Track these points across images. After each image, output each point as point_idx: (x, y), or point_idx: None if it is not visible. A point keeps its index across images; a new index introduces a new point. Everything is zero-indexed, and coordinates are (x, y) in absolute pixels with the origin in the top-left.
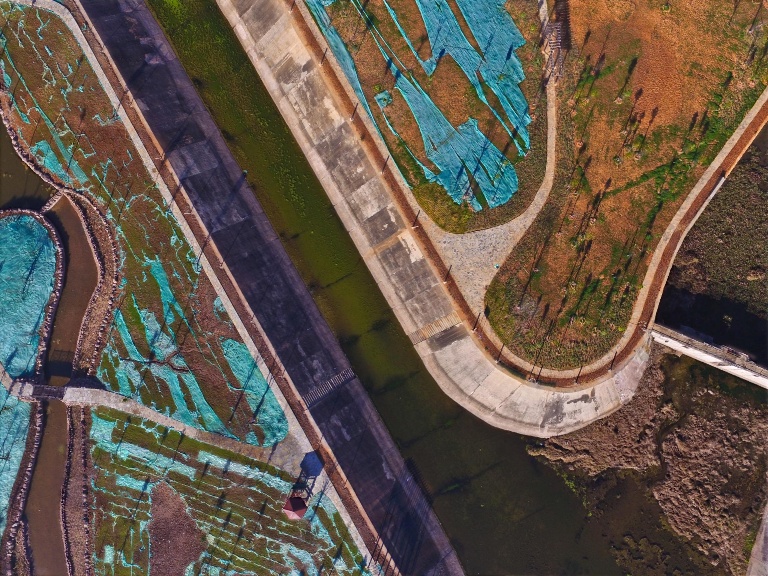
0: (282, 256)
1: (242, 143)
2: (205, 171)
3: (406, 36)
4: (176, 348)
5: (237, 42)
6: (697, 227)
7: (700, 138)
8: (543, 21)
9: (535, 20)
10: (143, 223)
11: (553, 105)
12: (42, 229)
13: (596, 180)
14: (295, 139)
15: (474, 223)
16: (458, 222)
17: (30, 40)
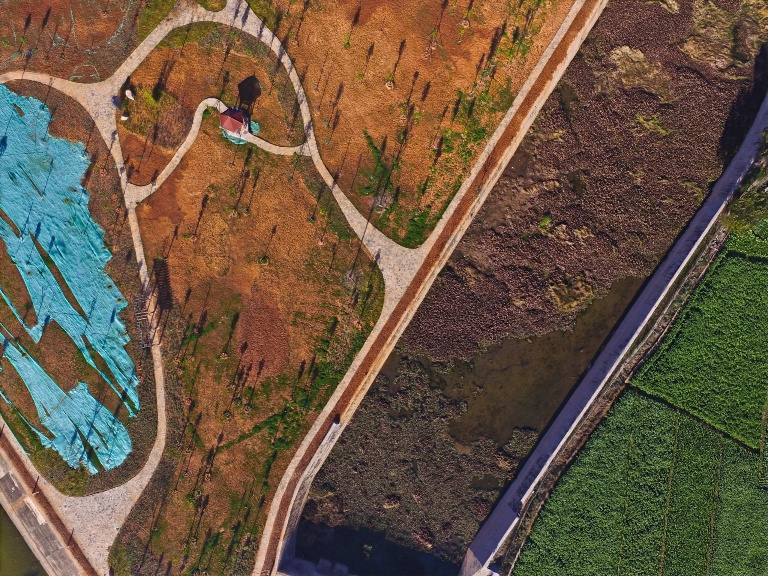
0: None
1: None
2: None
3: (11, 304)
4: None
5: None
6: (331, 460)
7: (310, 384)
8: (143, 282)
9: (136, 282)
10: None
11: (159, 365)
12: None
13: (208, 436)
14: None
15: (91, 486)
16: (76, 486)
17: None
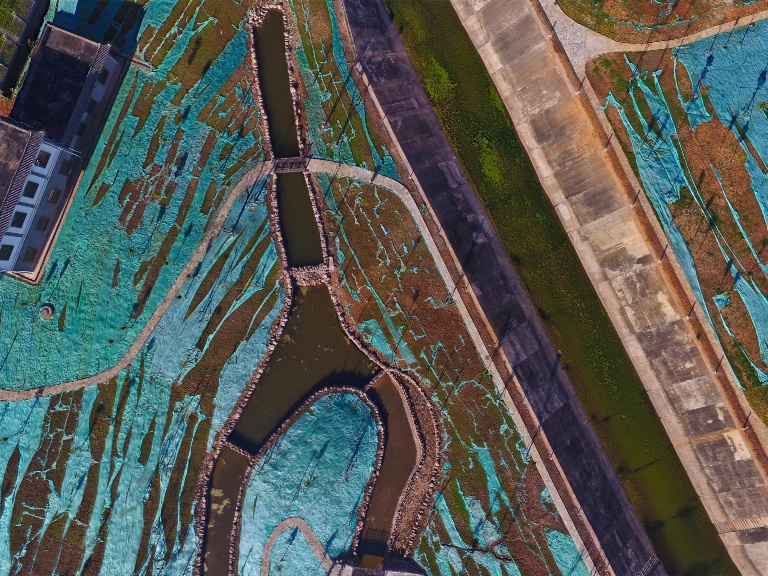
0: (595, 440)
1: (557, 323)
2: (530, 356)
3: (748, 238)
4: (500, 537)
5: (558, 221)
6: None
7: None
8: None
9: None
10: (472, 409)
11: None
12: (365, 408)
13: None
14: (611, 322)
15: None
16: None
17: (366, 218)
